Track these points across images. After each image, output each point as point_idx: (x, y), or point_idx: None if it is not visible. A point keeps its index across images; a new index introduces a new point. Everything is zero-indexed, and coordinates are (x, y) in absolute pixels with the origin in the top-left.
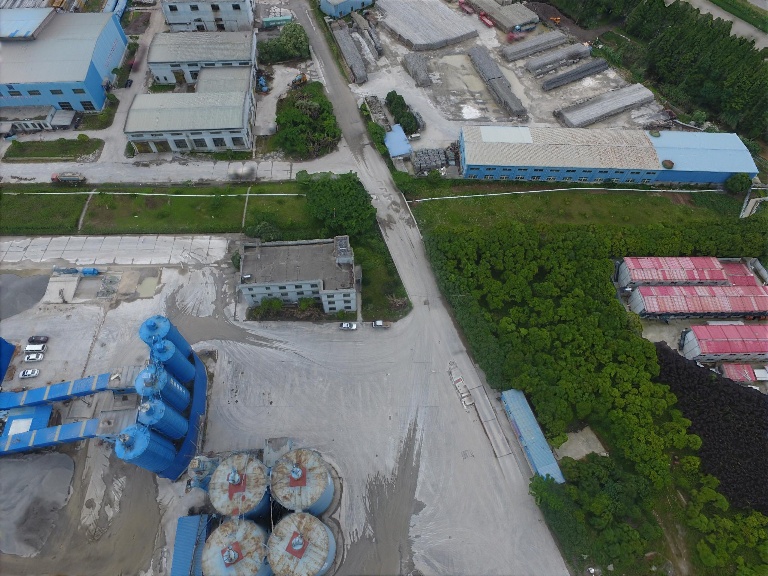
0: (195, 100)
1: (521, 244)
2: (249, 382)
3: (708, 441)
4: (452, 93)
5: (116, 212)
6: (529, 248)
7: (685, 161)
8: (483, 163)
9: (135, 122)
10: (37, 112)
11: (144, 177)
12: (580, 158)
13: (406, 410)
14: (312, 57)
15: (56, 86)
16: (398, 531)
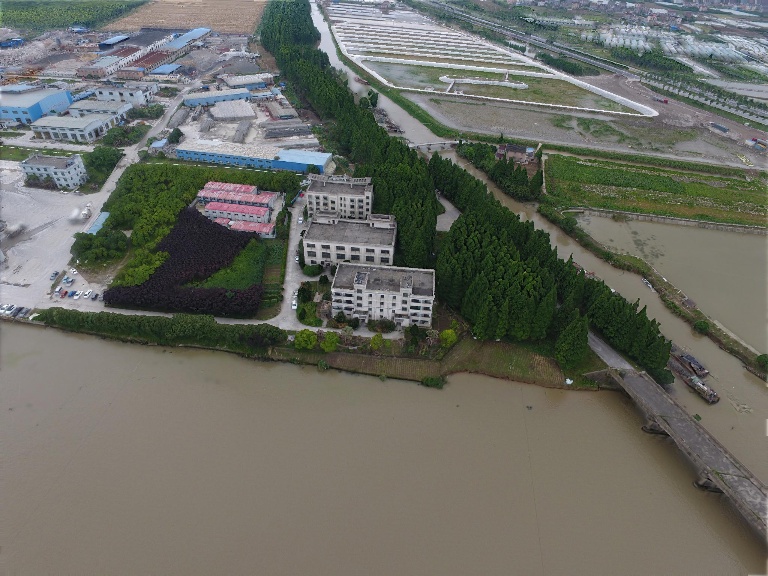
0: (73, 119)
1: (161, 169)
2: (1, 201)
3: (173, 233)
4: (214, 135)
5: (4, 152)
6: (165, 172)
7: (288, 158)
8: (183, 149)
9: (37, 123)
10: (4, 121)
11: (30, 145)
12: (234, 152)
13: (58, 216)
14: (159, 118)
15: (15, 109)
16: (12, 243)
